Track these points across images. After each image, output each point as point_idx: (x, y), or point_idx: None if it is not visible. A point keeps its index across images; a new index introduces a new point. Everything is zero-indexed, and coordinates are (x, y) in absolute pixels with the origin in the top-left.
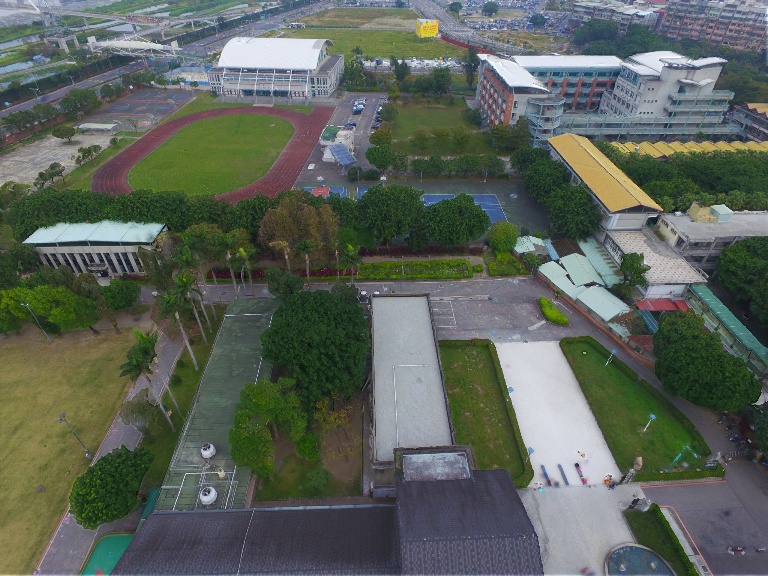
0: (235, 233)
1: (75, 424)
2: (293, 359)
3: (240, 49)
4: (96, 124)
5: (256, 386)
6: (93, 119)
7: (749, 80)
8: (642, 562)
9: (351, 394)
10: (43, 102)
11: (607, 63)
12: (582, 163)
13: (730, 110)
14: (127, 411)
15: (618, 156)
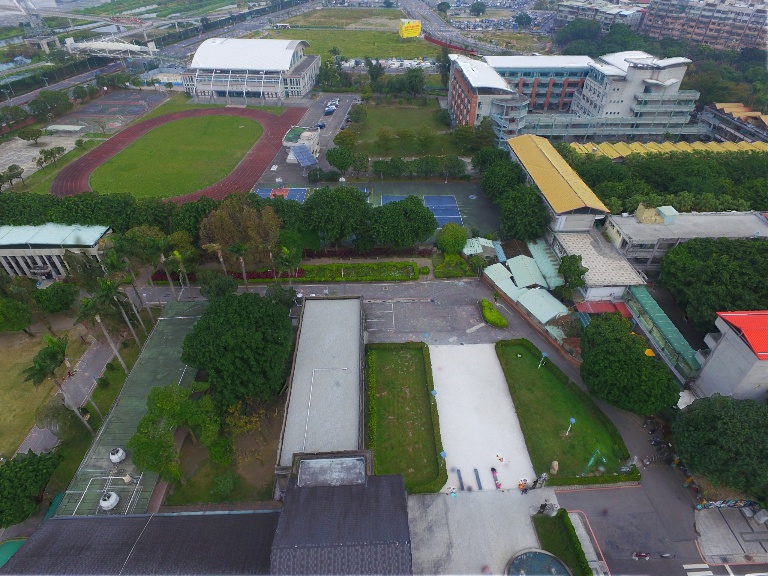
0: (176, 235)
1: None
2: (209, 363)
3: (214, 50)
4: (64, 126)
5: (162, 390)
6: (63, 121)
7: (719, 80)
8: (543, 568)
9: (267, 398)
10: (15, 104)
11: (578, 63)
12: (536, 164)
13: (701, 110)
14: (41, 415)
15: (573, 157)
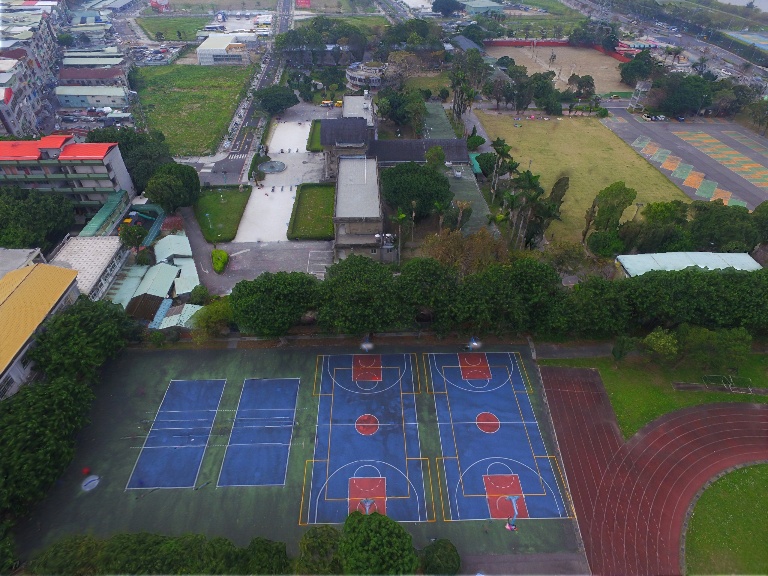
0: None
1: None
2: None
3: None
4: None
5: None
6: None
7: None
8: None
9: None
10: None
11: None
12: None
13: None
14: None
15: None
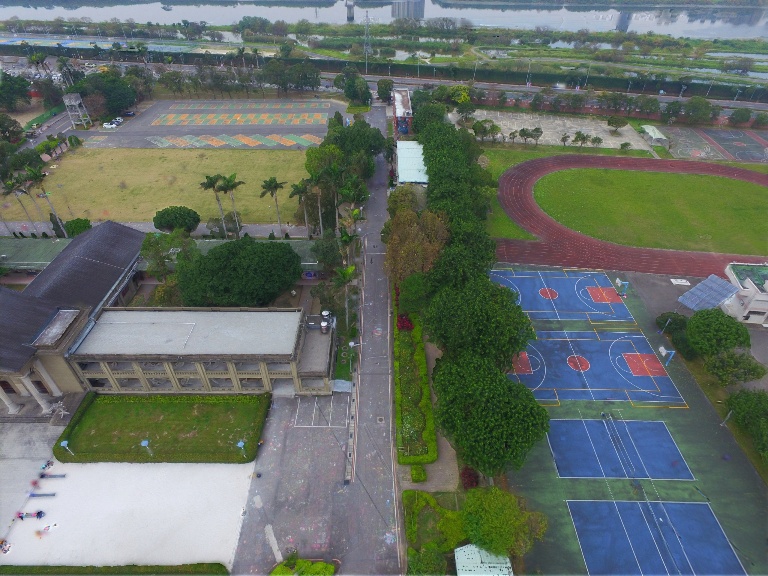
0: None
1: (252, 212)
2: None
3: None
4: (655, 130)
5: None
6: (679, 130)
7: None
8: None
9: None
10: None
11: None
12: None
13: None
14: None
15: None
